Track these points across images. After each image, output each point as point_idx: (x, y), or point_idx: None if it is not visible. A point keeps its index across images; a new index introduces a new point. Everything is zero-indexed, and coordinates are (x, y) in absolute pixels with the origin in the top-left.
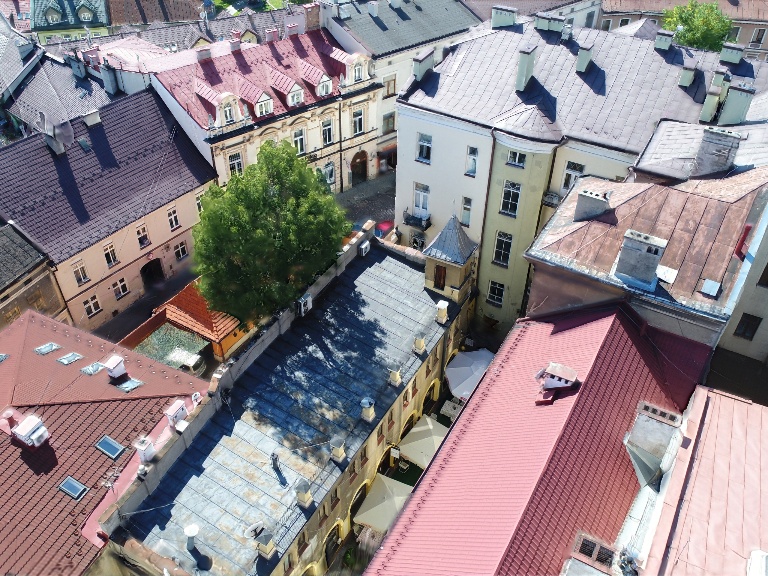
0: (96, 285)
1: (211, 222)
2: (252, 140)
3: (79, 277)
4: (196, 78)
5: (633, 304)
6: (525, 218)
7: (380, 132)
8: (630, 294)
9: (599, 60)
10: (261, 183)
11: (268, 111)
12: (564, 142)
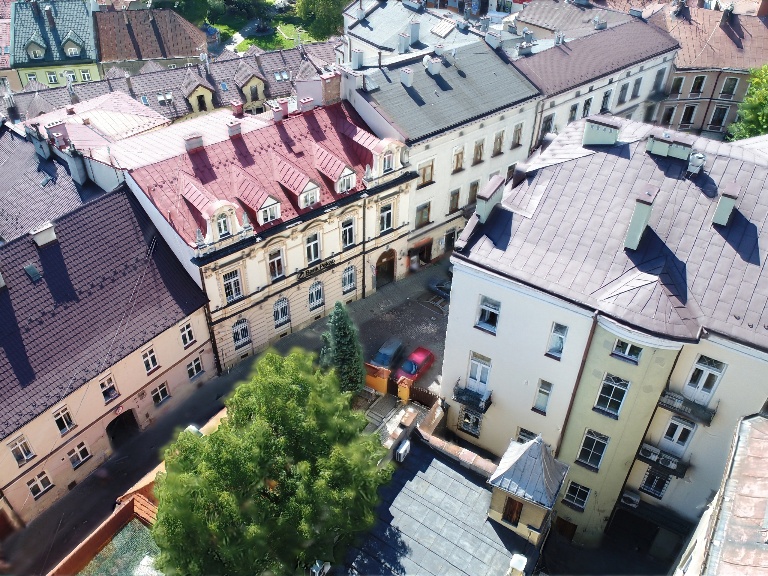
0: (44, 460)
1: (177, 505)
2: (253, 254)
3: (20, 455)
4: (183, 174)
5: None
6: (631, 421)
7: (412, 226)
8: None
9: (746, 207)
10: (257, 441)
11: (274, 216)
12: (702, 336)
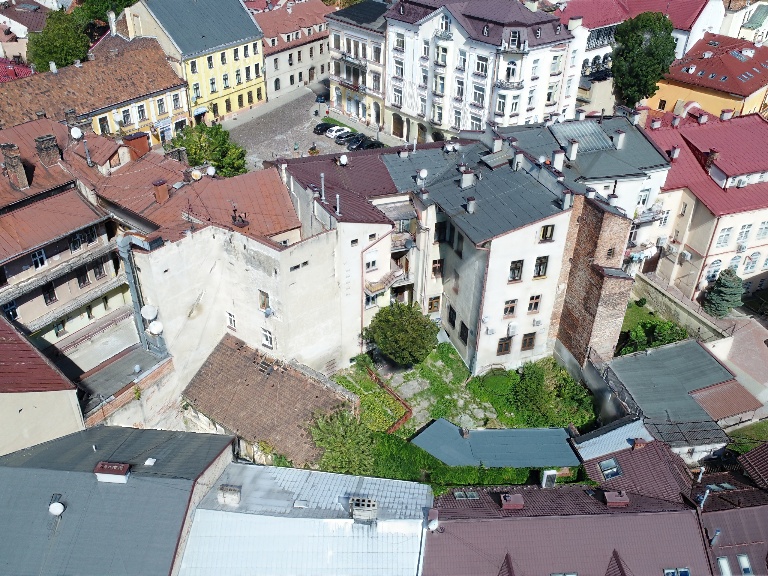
0: None
1: None
2: None
3: None
4: None
5: None
6: None
7: None
8: None
9: None
10: None
11: None
12: None
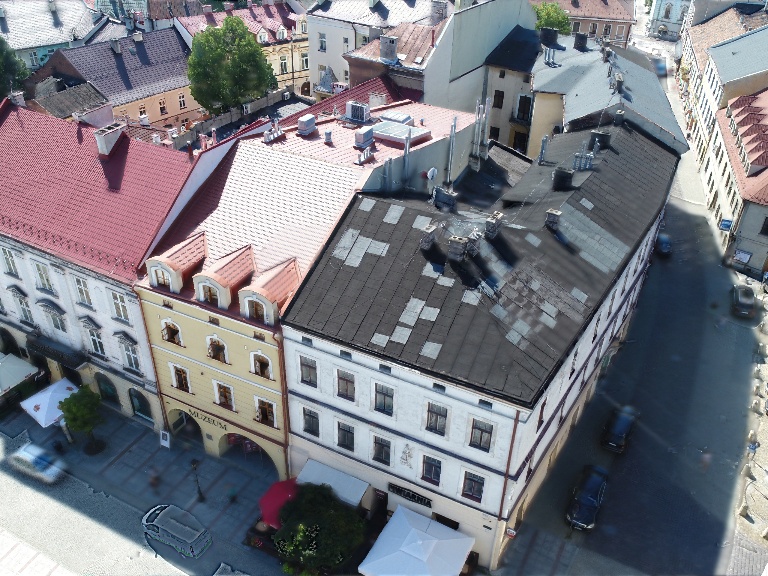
0: None
1: (196, 47)
2: None
3: None
4: (202, 22)
5: (390, 74)
6: None
7: None
8: (386, 67)
9: None
10: (222, 30)
11: None
12: None
